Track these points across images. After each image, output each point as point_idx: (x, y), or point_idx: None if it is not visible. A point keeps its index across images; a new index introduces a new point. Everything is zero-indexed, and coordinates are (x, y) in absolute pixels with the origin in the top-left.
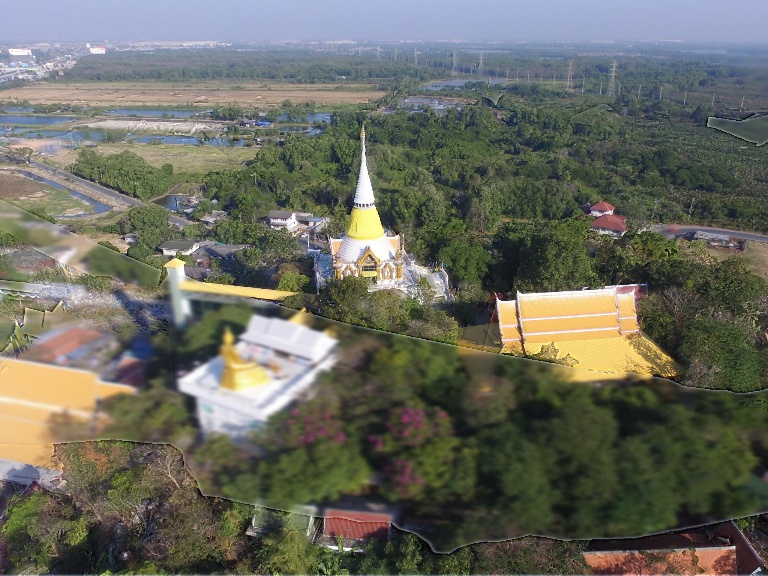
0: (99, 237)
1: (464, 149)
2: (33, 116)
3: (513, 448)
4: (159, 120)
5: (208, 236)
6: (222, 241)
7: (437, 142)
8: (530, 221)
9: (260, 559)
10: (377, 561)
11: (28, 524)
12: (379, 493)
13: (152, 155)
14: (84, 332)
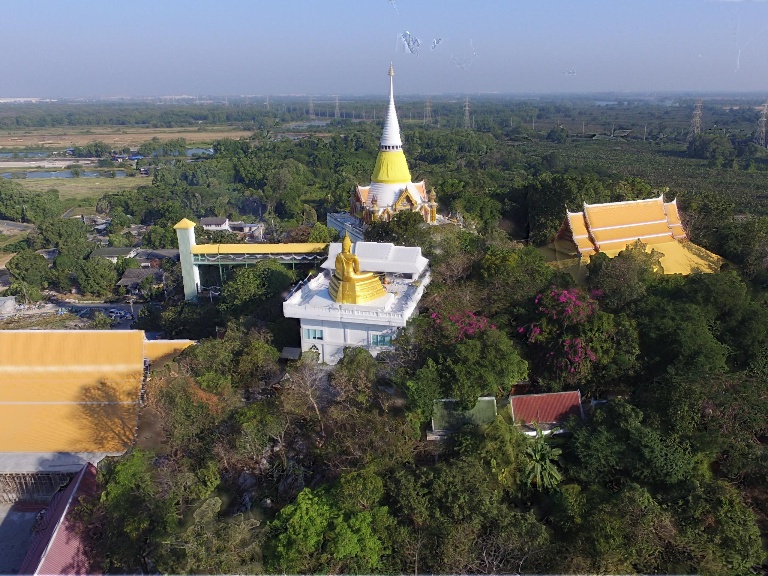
0: (1, 257)
1: (366, 165)
2: None
3: None
4: (10, 160)
5: (138, 246)
6: None
7: (335, 161)
8: None
9: (466, 453)
10: (593, 430)
11: (140, 483)
12: None
13: None
14: None
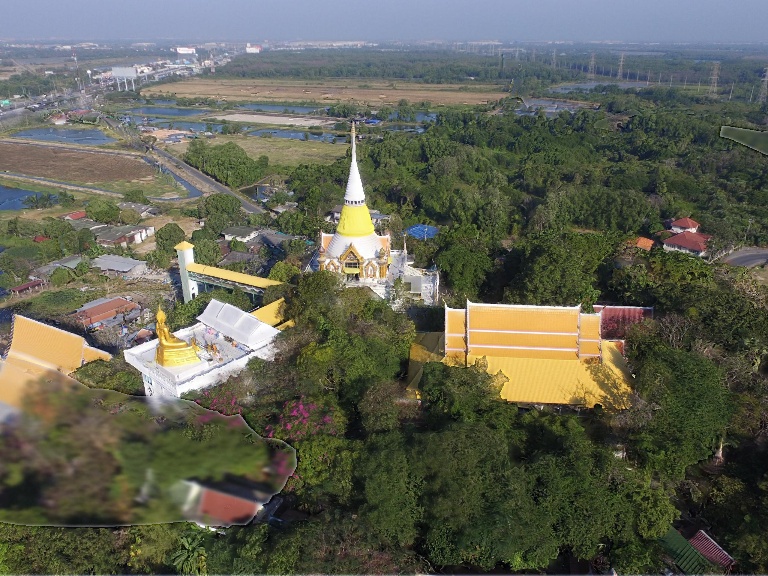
0: (180, 219)
1: (560, 154)
2: (175, 108)
3: None
4: (280, 115)
5: (273, 225)
6: (283, 231)
7: (535, 146)
8: (601, 233)
9: None
10: None
11: None
12: None
13: (258, 147)
14: None
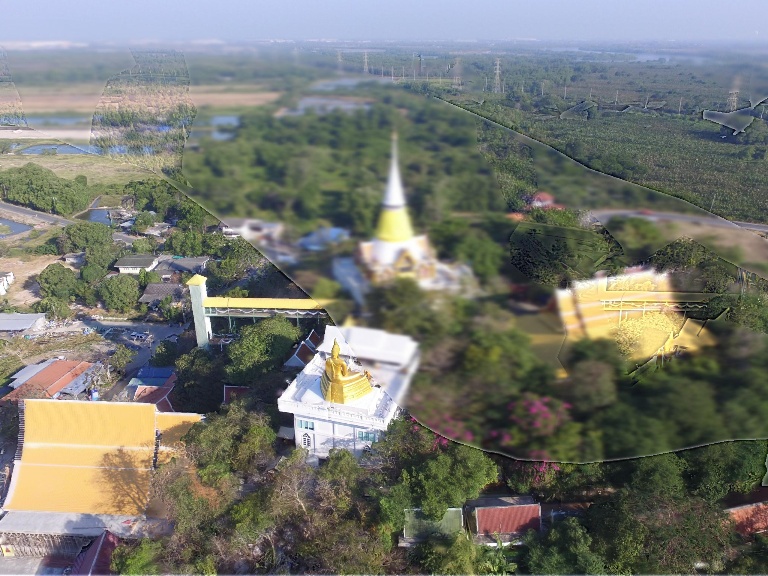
0: (32, 259)
1: None
2: None
3: None
4: None
5: (160, 250)
6: (178, 254)
7: None
8: None
9: (430, 568)
10: (546, 550)
11: (147, 575)
12: None
13: (52, 167)
14: (738, 337)
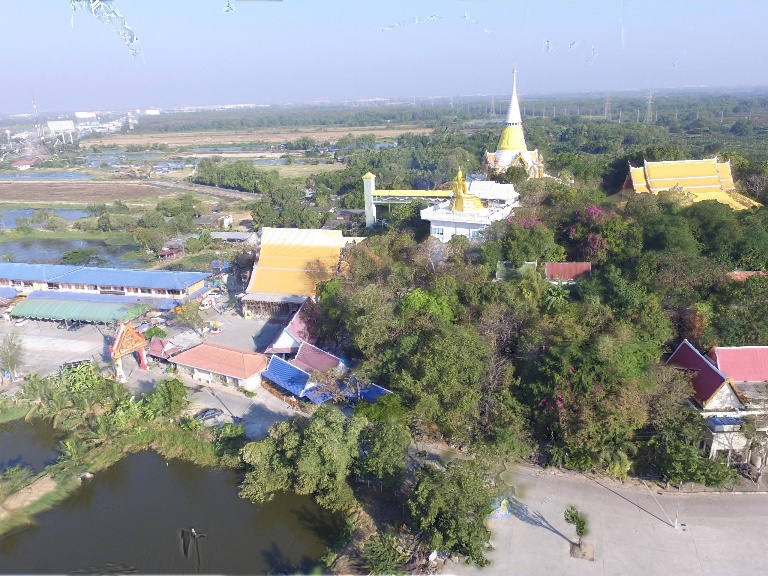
0: (244, 213)
1: None
2: None
3: (755, 7)
4: (240, 152)
5: None
6: None
7: None
8: None
9: None
10: (590, 280)
11: (338, 292)
12: (697, 40)
13: None
14: None
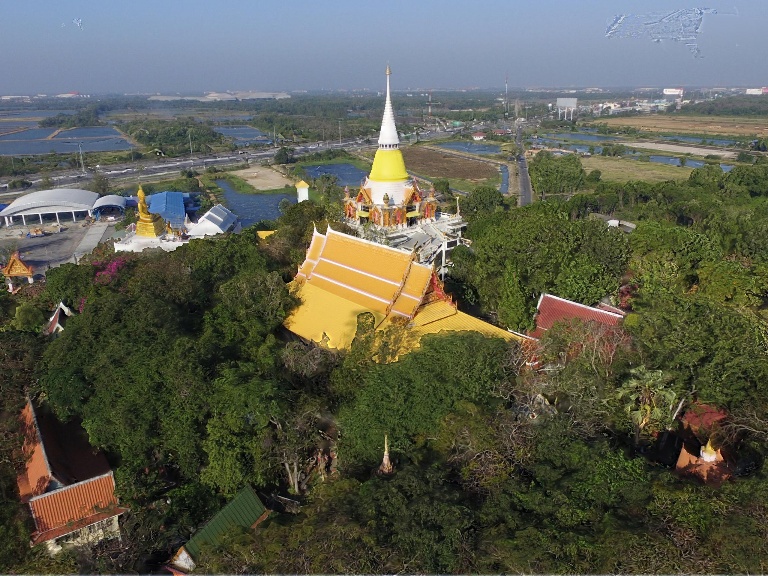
0: None
1: None
2: (593, 135)
3: None
4: (694, 146)
5: None
6: None
7: None
8: None
9: None
10: None
11: None
12: None
13: (618, 167)
14: None
